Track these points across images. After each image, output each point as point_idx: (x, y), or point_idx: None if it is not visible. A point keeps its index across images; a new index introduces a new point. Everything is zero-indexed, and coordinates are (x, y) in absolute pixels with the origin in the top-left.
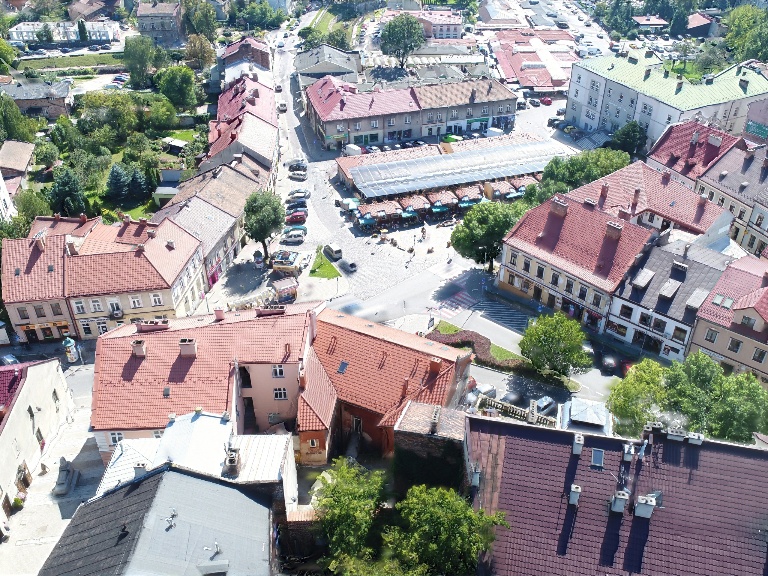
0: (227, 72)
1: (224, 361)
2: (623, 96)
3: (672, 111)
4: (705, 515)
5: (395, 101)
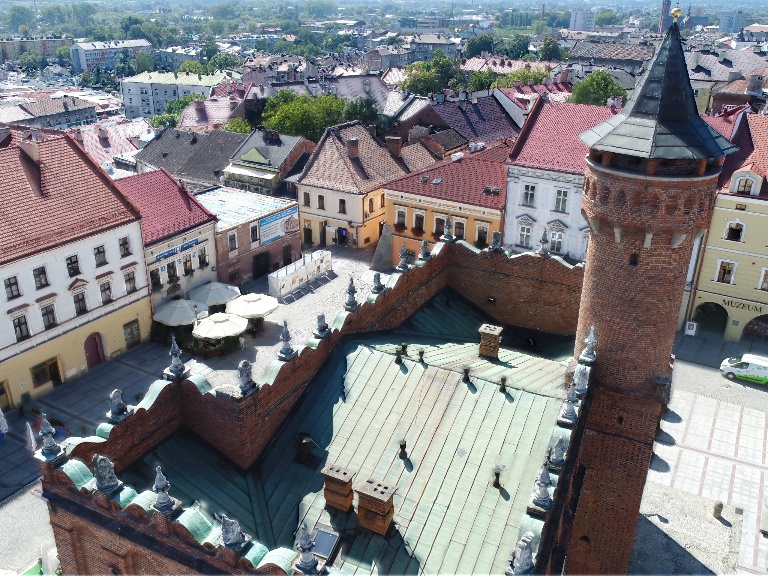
0: None
1: (123, 138)
2: (167, 91)
3: (203, 89)
4: (348, 91)
5: (13, 113)
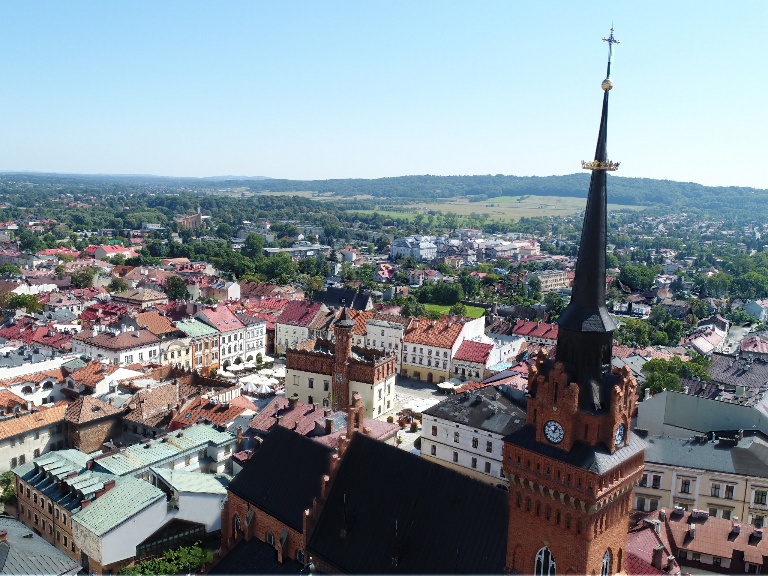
0: (700, 327)
1: None
2: None
3: None
4: None
5: None
